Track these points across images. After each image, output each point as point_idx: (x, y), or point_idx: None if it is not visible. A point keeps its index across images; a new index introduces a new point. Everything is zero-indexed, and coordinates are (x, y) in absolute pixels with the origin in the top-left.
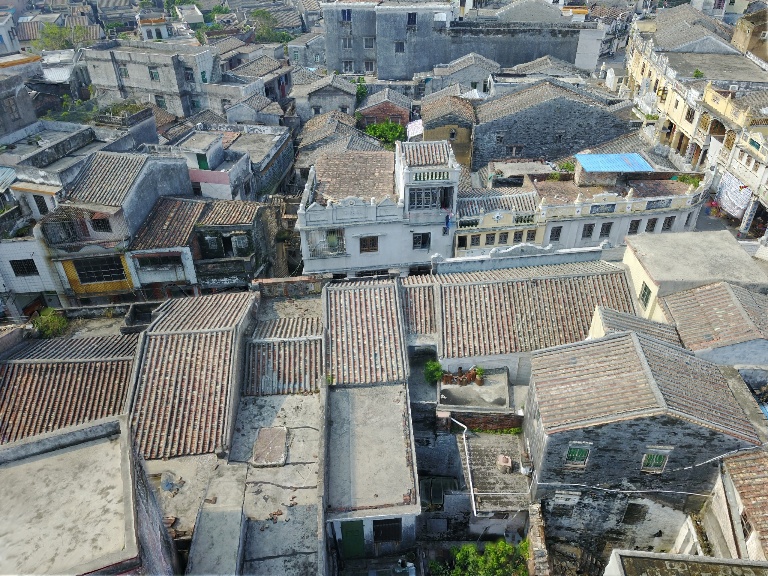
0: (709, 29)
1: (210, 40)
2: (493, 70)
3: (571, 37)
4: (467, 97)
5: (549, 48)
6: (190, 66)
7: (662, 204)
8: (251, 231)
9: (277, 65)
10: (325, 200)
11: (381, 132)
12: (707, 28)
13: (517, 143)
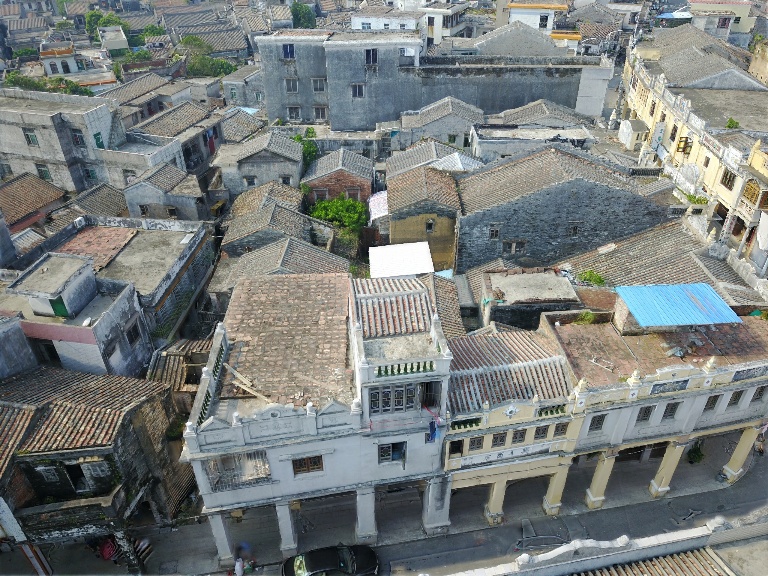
0: (724, 57)
1: (127, 76)
2: (475, 120)
3: (571, 77)
4: (446, 166)
5: (544, 90)
6: (78, 127)
7: (756, 372)
8: (112, 454)
9: (203, 114)
10: (236, 389)
11: (334, 213)
12: (723, 57)
13: (518, 237)
